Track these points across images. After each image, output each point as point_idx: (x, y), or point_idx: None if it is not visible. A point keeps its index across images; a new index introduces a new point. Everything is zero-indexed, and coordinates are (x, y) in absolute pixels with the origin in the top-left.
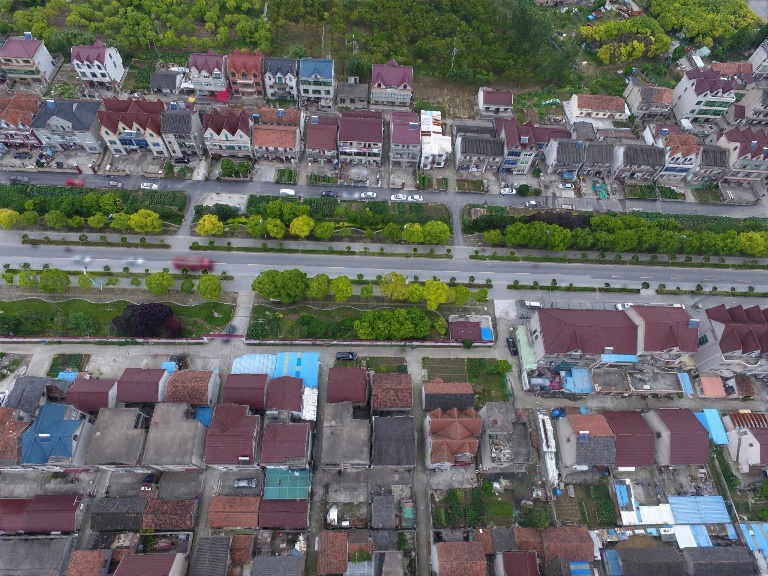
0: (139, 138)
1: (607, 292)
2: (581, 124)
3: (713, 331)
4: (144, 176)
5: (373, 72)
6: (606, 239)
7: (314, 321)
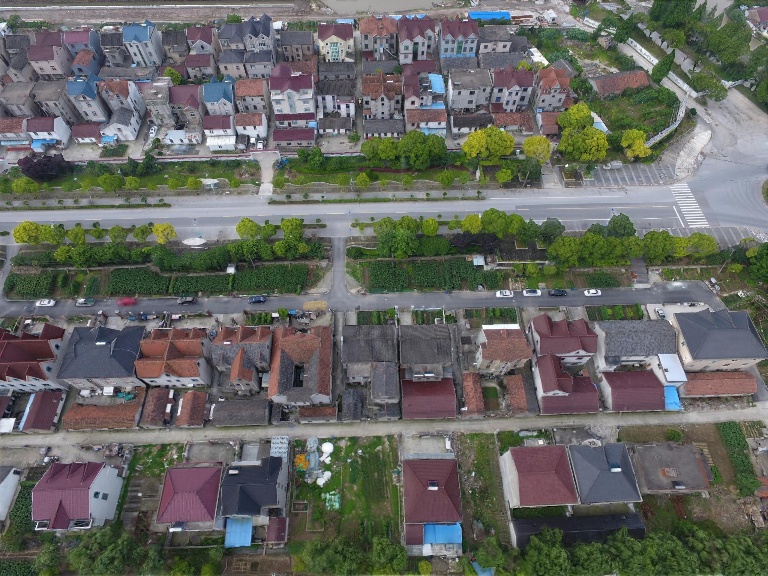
0: None
1: None
2: None
3: None
4: None
5: None
6: None
7: None
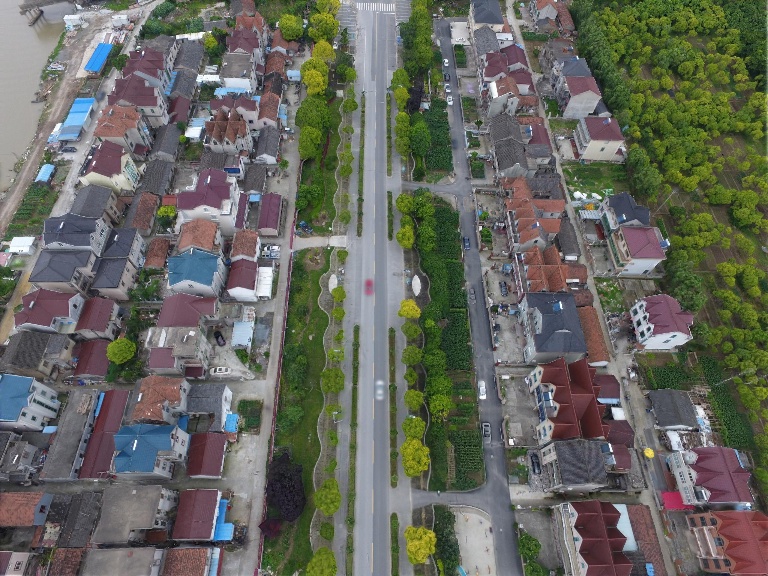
0: (545, 411)
1: None
2: None
3: None
4: (503, 421)
5: None
6: None
7: None
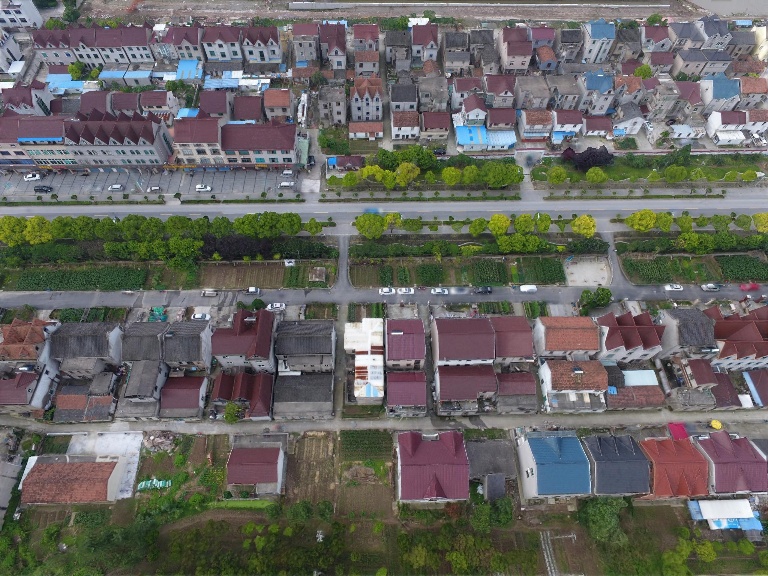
0: None
1: (213, 200)
2: (144, 389)
3: (158, 132)
4: None
5: (465, 455)
6: (200, 218)
7: (468, 159)
